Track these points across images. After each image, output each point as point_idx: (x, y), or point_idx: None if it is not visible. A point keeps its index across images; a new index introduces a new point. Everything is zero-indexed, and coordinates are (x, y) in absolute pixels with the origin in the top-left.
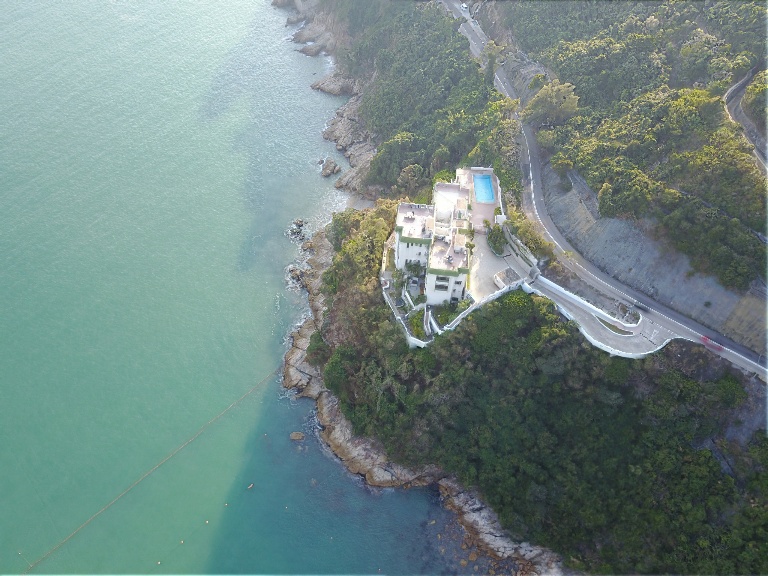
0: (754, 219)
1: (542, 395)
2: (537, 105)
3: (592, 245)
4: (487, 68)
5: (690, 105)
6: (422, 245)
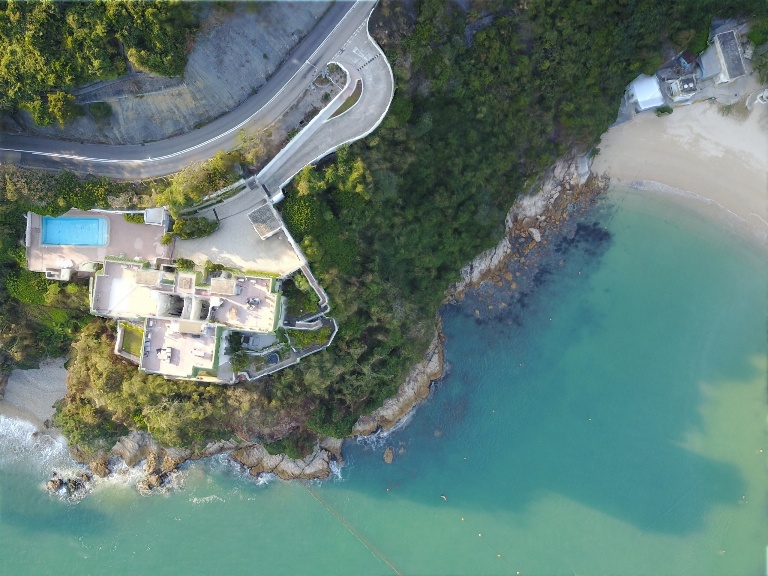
0: None
1: (400, 196)
2: None
3: (219, 98)
4: None
5: None
6: None
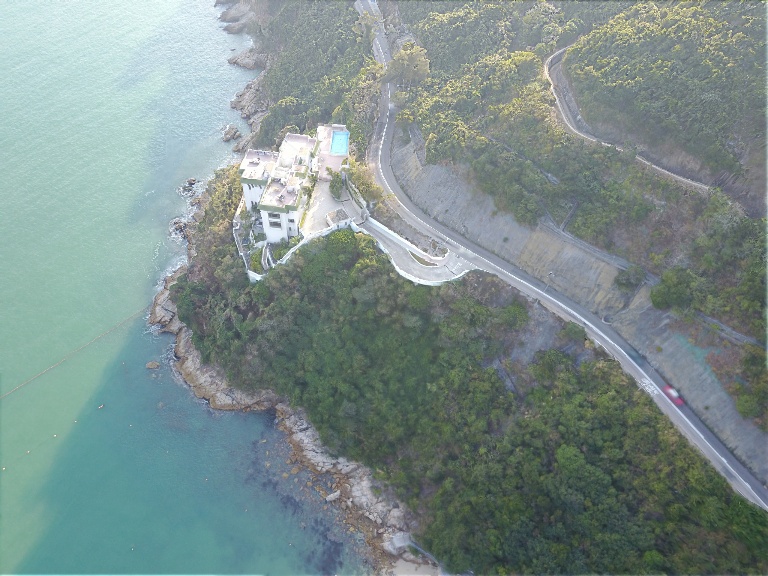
0: (543, 161)
1: (360, 323)
2: None
3: (418, 190)
4: (364, 37)
5: (514, 64)
6: (262, 187)
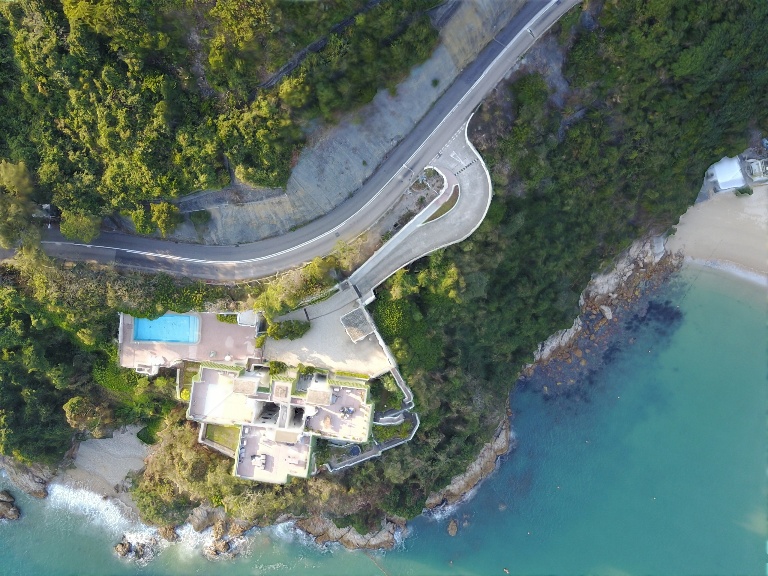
0: None
1: (484, 290)
2: (6, 233)
3: (317, 204)
4: None
5: None
6: None
